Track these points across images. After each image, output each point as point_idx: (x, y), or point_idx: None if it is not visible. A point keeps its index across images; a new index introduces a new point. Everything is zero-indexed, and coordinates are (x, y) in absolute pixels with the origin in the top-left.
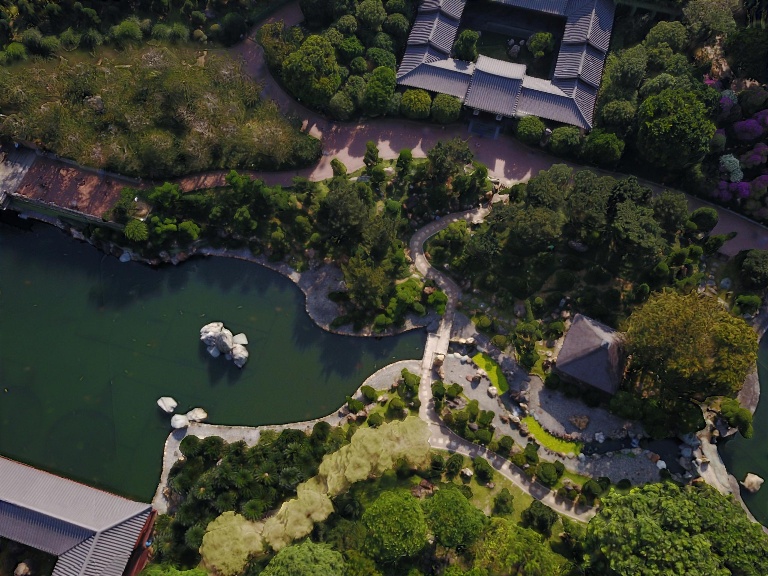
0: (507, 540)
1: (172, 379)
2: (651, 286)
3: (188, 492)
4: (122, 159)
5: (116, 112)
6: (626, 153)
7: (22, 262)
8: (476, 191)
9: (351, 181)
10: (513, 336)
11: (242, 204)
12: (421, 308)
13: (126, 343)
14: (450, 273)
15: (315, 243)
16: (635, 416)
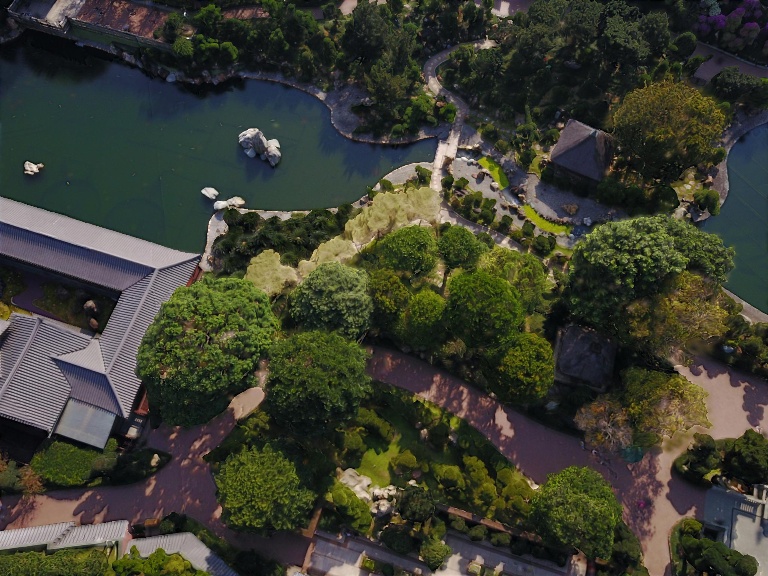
0: (505, 254)
1: (213, 176)
2: None
3: (231, 251)
4: None
5: None
6: None
7: (80, 81)
8: (483, 24)
9: None
10: (514, 137)
11: None
12: (433, 119)
13: (173, 147)
14: (459, 93)
15: (341, 61)
16: (618, 197)
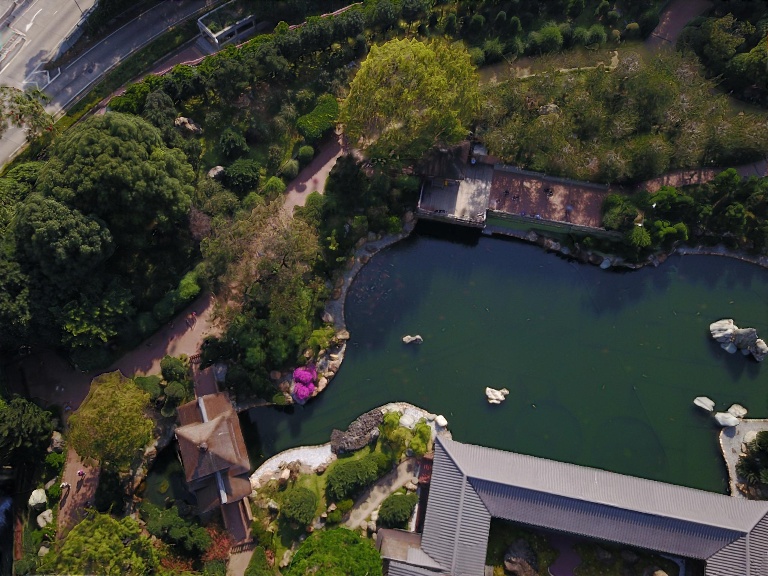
0: None
1: (693, 379)
2: None
3: None
4: (624, 166)
5: (598, 120)
6: None
7: (502, 278)
8: None
9: None
10: None
11: (713, 201)
12: None
13: (634, 348)
14: None
15: None
16: None
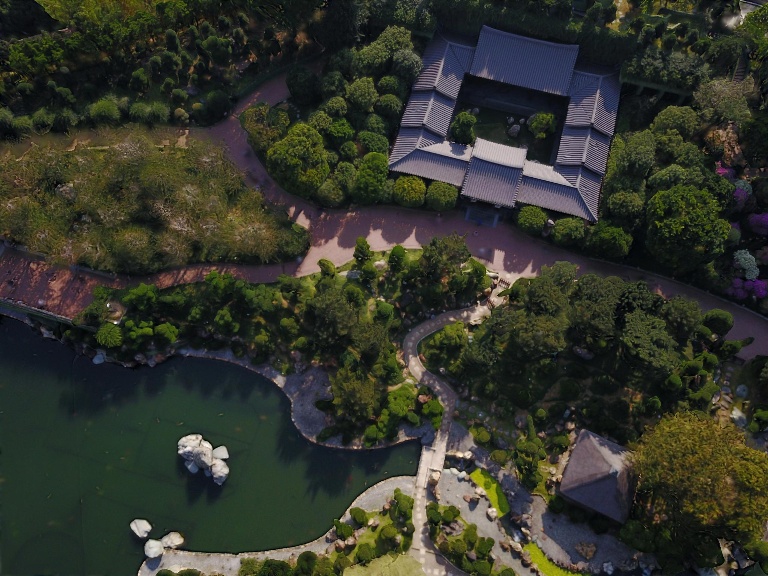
0: None
1: (147, 497)
2: (662, 398)
3: None
4: (94, 259)
5: (89, 206)
6: (634, 246)
7: None
8: (474, 287)
9: (340, 276)
10: (514, 454)
11: (224, 301)
12: (415, 418)
13: (98, 456)
14: (446, 378)
15: (301, 348)
16: (647, 549)
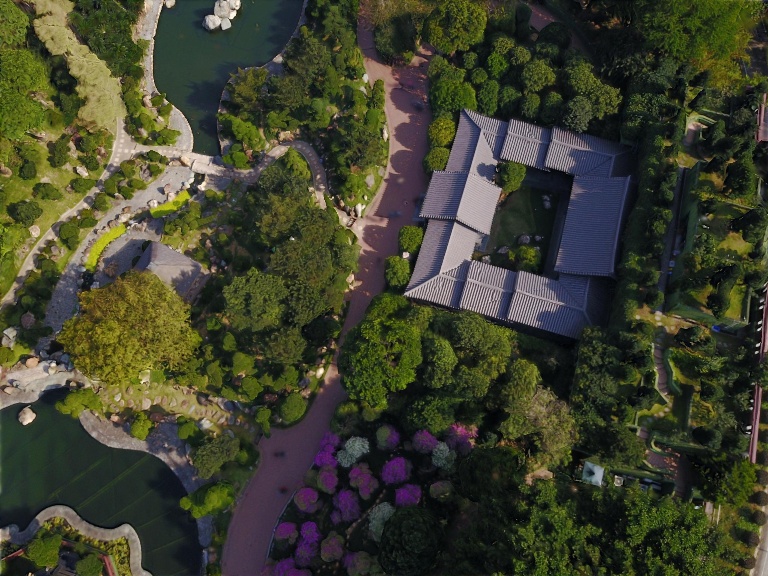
0: None
1: None
2: None
3: None
4: None
5: None
6: None
7: None
8: None
9: (360, 86)
10: None
11: None
12: (235, 148)
13: None
14: None
15: None
16: None
